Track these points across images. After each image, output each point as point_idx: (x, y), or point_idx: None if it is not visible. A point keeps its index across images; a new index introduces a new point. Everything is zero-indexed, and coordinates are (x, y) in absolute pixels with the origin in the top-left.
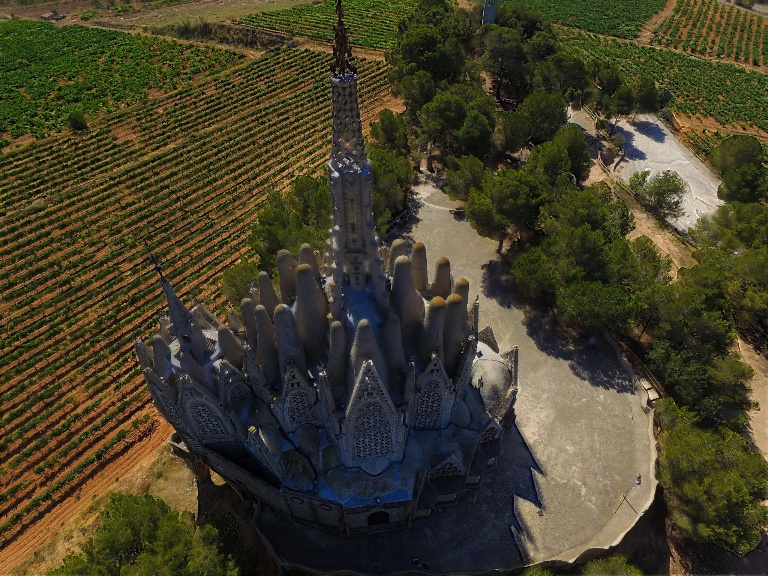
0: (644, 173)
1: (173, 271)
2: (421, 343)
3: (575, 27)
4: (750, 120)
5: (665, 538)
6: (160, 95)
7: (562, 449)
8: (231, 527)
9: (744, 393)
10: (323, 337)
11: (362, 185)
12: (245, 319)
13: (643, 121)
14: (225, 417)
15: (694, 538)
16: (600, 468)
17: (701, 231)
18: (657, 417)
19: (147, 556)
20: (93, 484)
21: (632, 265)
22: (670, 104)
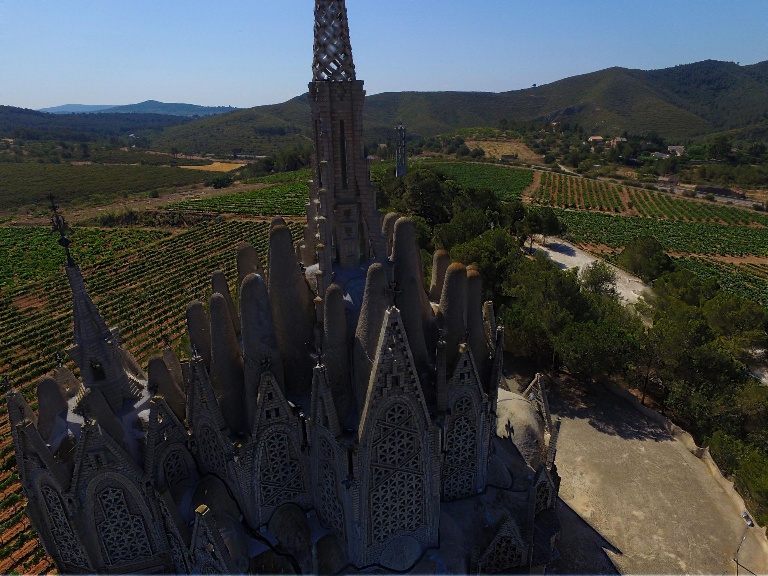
0: (574, 269)
1: None
2: None
3: None
4: None
5: None
6: None
7: (629, 516)
8: None
9: None
10: (308, 343)
11: (354, 99)
12: (192, 333)
13: (552, 243)
14: (152, 513)
15: None
16: (686, 530)
17: (645, 308)
18: None
19: None
20: None
21: (611, 314)
22: None
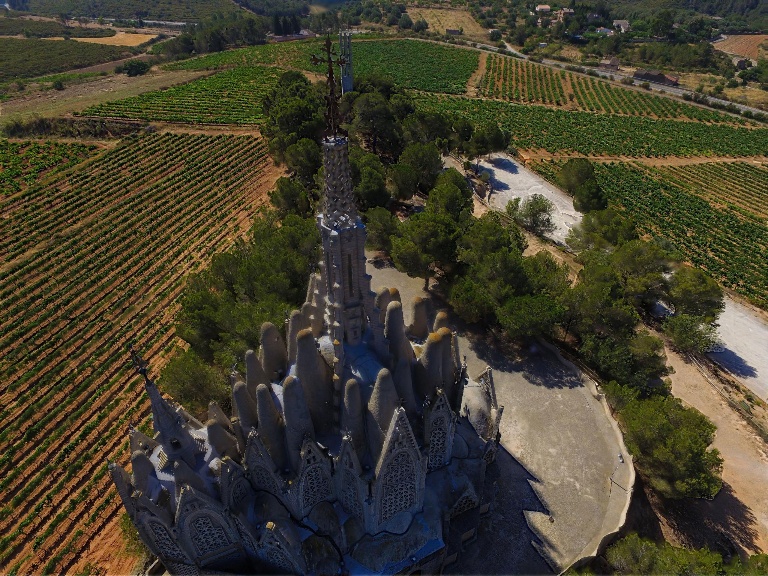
0: (516, 200)
1: (73, 388)
2: (422, 383)
3: (413, 89)
4: (570, 147)
5: (650, 506)
6: (0, 200)
7: (546, 453)
8: None
9: (662, 361)
10: (328, 402)
11: (358, 239)
12: (240, 405)
13: (497, 158)
14: (228, 524)
15: (674, 496)
16: (583, 460)
17: (574, 239)
18: (607, 401)
19: None
20: None
21: (544, 276)
22: (511, 142)
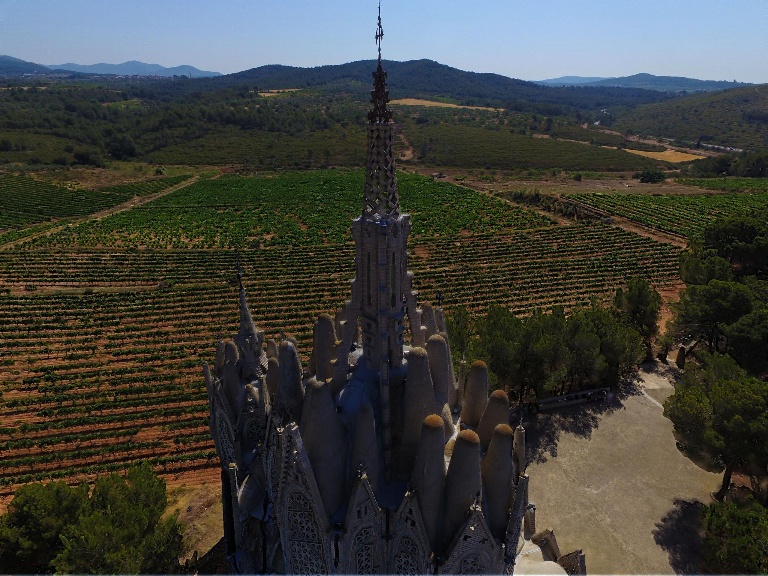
0: None
1: None
2: None
3: None
4: None
5: None
6: None
7: None
8: (188, 567)
9: None
10: None
11: None
12: None
13: None
14: None
15: None
16: None
17: None
18: None
19: (100, 517)
20: (191, 475)
21: None
22: None
